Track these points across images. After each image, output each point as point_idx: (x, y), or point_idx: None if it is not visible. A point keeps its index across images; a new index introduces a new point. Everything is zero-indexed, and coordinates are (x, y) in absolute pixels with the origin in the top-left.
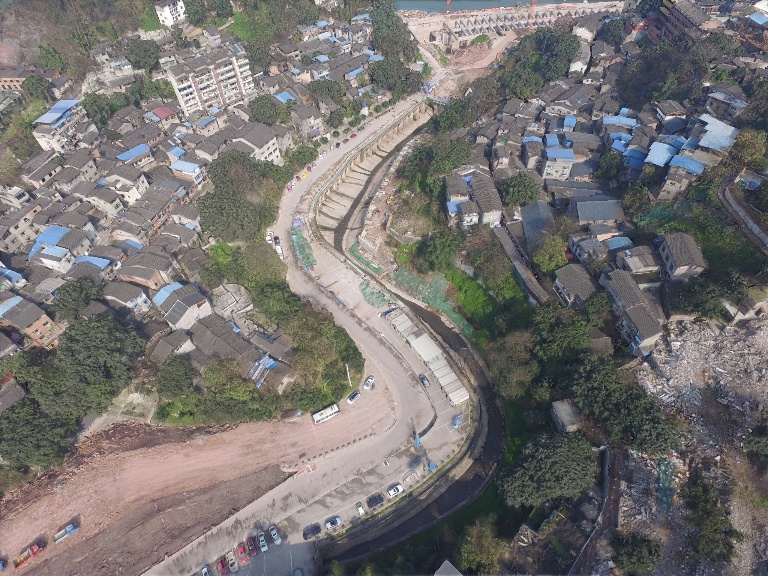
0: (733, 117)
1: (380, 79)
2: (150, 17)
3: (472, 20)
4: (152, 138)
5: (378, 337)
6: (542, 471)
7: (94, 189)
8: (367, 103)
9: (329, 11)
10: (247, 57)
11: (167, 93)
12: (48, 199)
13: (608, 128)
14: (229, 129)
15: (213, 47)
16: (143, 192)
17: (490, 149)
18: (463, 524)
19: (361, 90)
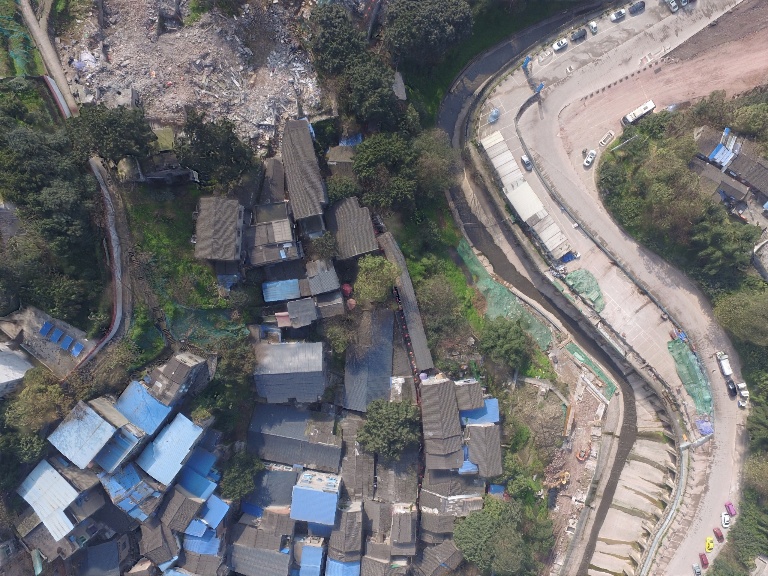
0: (5, 545)
1: None
2: None
3: None
4: None
5: (580, 222)
6: (443, 3)
7: None
8: None
9: None
10: None
11: None
12: None
13: (215, 571)
14: None
15: None
16: None
17: (410, 570)
18: (492, 31)
19: None
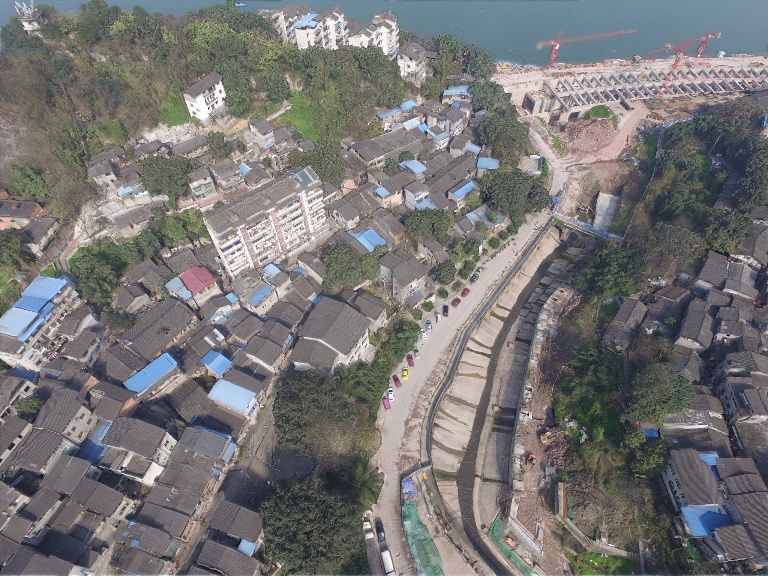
0: None
1: (501, 204)
2: (176, 106)
3: (579, 79)
4: (179, 331)
5: None
6: None
7: (84, 477)
8: (482, 238)
9: (418, 87)
10: (318, 179)
11: (200, 231)
12: (2, 515)
13: None
14: (293, 299)
15: (263, 149)
16: (166, 457)
17: (705, 362)
18: None
19: (471, 215)
